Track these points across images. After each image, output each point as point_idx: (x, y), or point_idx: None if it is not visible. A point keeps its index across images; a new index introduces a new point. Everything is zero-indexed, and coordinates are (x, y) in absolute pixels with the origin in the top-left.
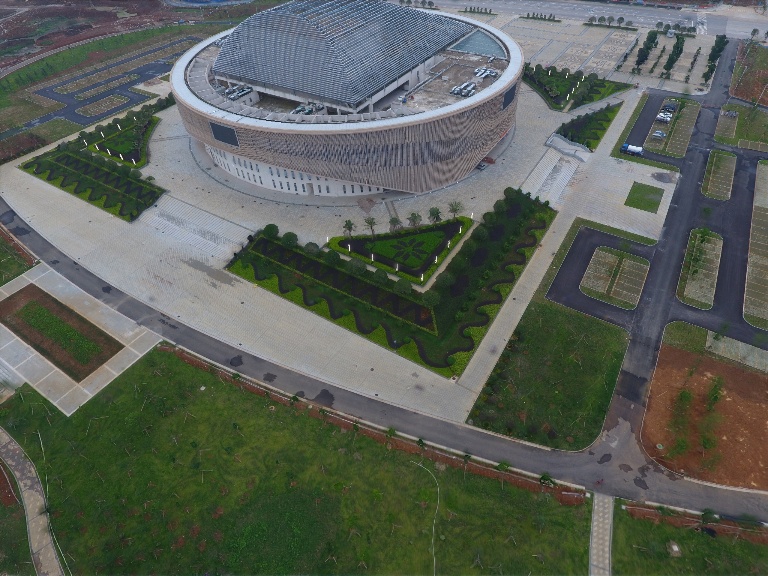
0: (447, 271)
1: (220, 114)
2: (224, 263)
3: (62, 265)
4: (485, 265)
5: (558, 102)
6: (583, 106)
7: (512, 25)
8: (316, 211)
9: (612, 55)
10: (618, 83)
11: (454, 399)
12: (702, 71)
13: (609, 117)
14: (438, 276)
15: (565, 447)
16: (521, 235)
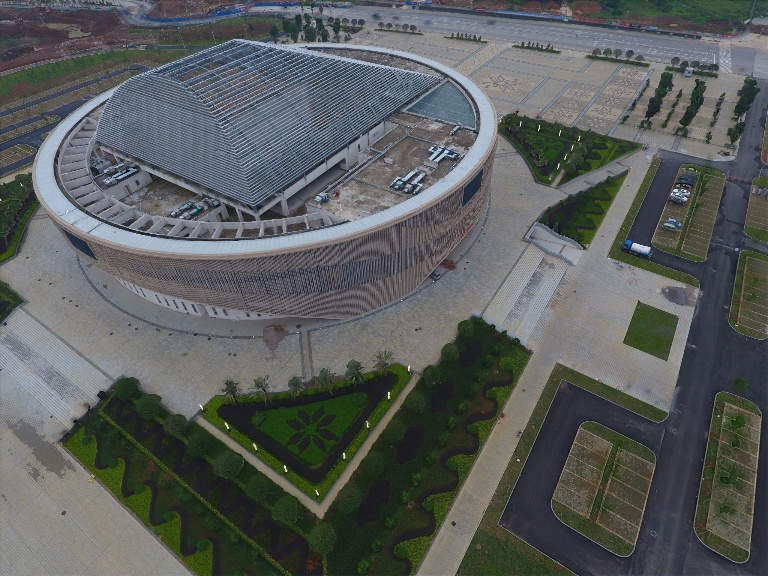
0: (360, 471)
1: (73, 217)
2: (62, 431)
3: None
4: (418, 458)
5: (546, 172)
6: (577, 178)
7: (503, 56)
8: (205, 345)
9: (618, 100)
10: (623, 142)
11: None
12: (727, 126)
13: (609, 194)
14: (338, 495)
15: None
16: (476, 397)
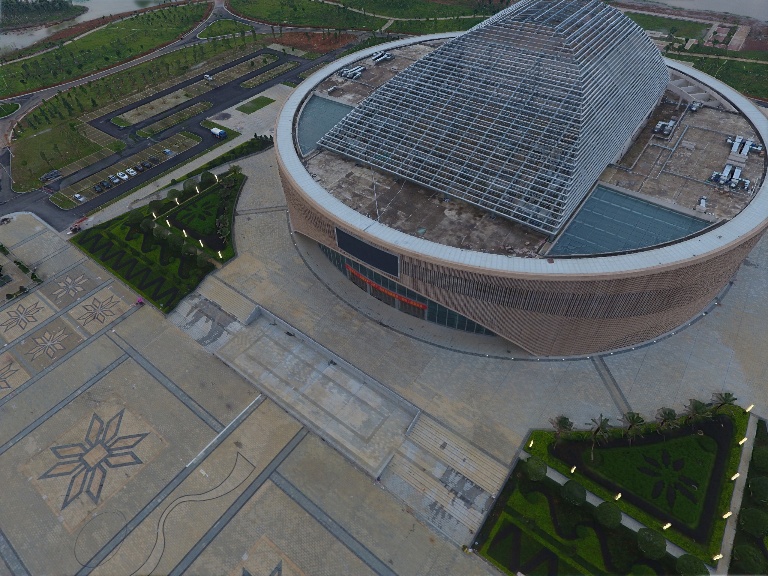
0: None
1: None
2: None
3: None
4: None
5: None
6: None
7: None
8: None
9: None
10: (95, 233)
11: None
12: None
13: None
14: None
15: (384, 37)
16: None
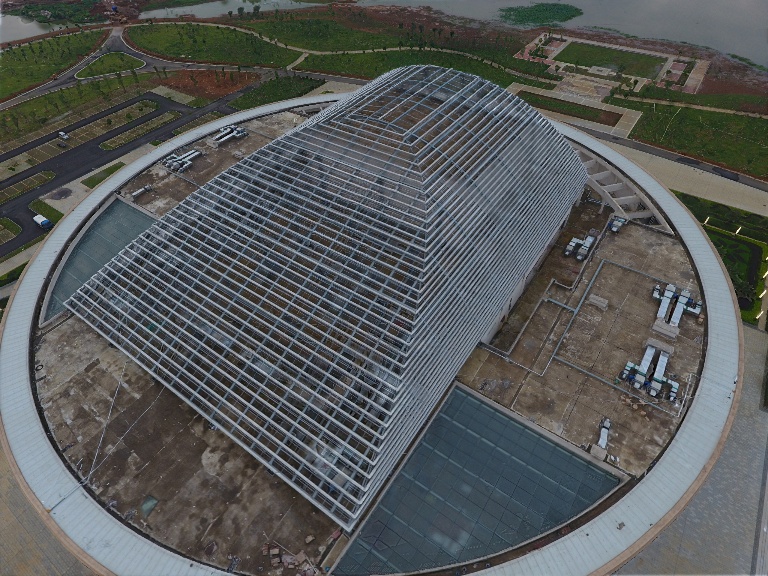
0: None
1: None
2: None
3: (607, 136)
4: None
5: None
6: None
7: None
8: None
9: None
10: None
11: (331, 86)
12: None
13: None
14: None
15: None
16: None
